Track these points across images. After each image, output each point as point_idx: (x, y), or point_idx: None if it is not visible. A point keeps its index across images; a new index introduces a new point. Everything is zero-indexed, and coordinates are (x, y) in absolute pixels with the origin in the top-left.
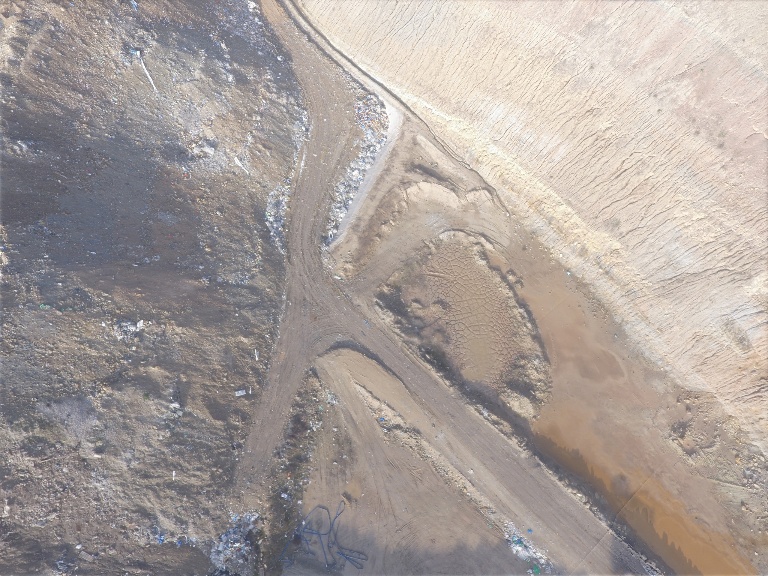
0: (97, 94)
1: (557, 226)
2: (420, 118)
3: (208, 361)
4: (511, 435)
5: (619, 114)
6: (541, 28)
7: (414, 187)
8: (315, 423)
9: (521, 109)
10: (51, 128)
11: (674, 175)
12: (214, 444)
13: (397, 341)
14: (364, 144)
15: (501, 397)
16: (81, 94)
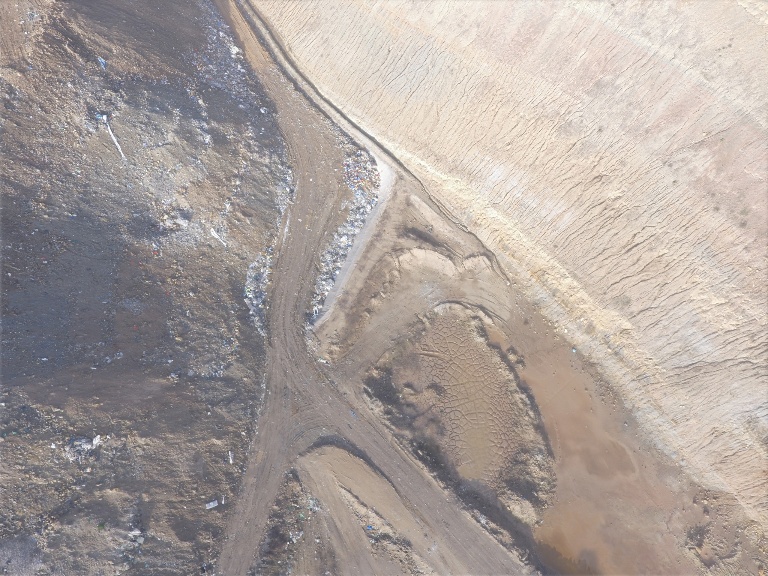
0: (57, 167)
1: (562, 299)
2: (414, 175)
3: (175, 473)
4: (511, 547)
5: (630, 183)
6: (545, 85)
7: (407, 254)
8: (295, 533)
9: (523, 171)
10: (2, 211)
11: (691, 254)
12: (180, 570)
13: (387, 435)
14: (353, 206)
15: (500, 499)
16: (38, 169)
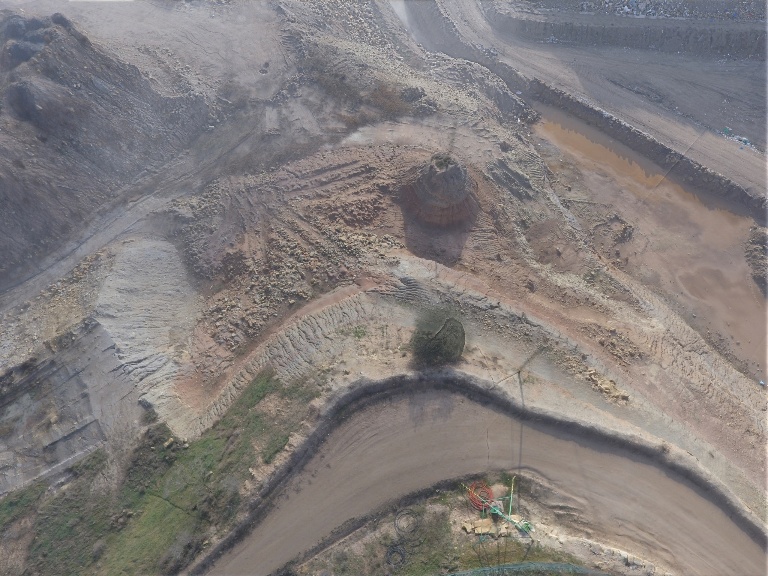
0: None
1: None
2: None
3: None
4: None
5: None
6: None
7: None
8: None
9: None
10: None
11: None
12: None
13: None
14: None
15: None
16: None
